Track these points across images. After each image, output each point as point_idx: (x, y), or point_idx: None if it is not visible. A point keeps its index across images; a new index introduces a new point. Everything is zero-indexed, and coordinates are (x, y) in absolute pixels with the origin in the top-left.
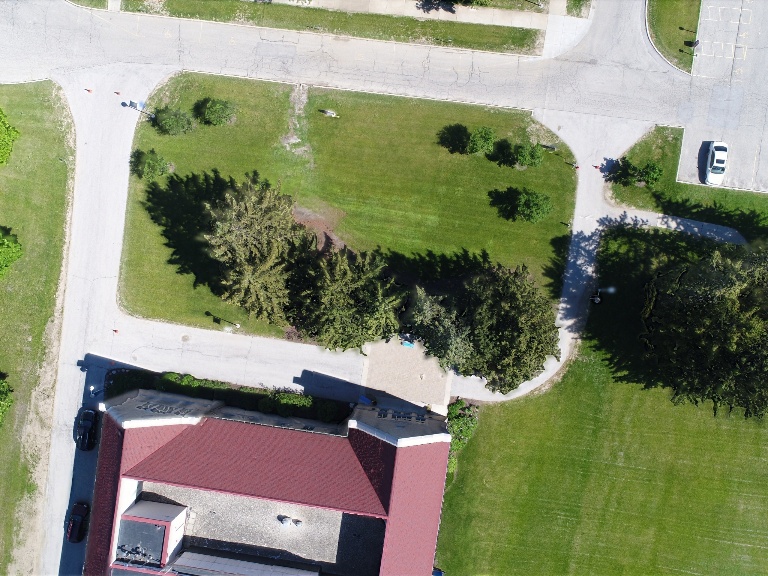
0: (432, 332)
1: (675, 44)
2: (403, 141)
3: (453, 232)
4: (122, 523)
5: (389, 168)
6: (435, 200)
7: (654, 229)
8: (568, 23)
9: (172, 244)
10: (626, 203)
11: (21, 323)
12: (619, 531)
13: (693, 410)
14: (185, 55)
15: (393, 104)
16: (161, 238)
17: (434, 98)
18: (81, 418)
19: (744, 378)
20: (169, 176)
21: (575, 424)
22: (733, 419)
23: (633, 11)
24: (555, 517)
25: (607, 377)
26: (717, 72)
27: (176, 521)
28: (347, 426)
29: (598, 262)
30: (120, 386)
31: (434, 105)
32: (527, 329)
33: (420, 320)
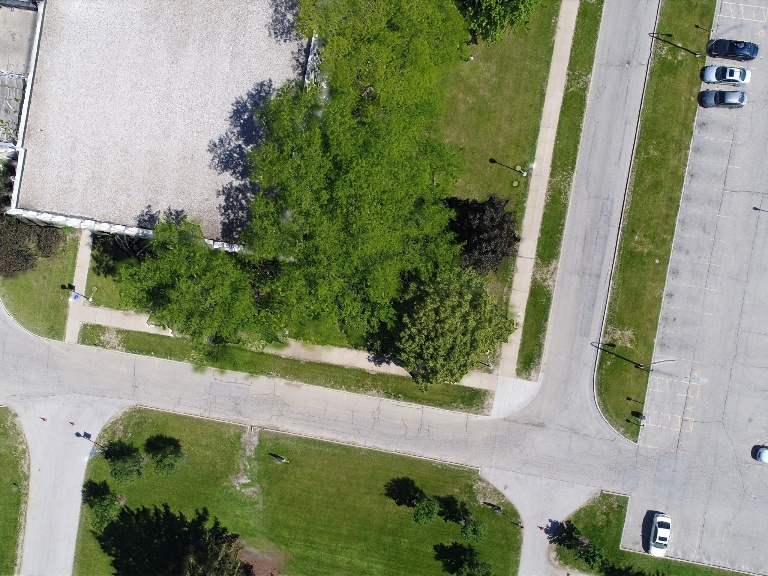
0: None
1: (622, 414)
2: (351, 490)
3: None
4: None
5: (337, 515)
6: (381, 549)
7: None
8: (517, 385)
9: (121, 575)
10: (570, 565)
11: None
12: None
13: None
14: (139, 390)
15: (342, 453)
16: (110, 568)
17: (383, 449)
18: None
19: None
20: (120, 508)
21: None
22: None
23: (582, 377)
24: None
25: None
26: (663, 443)
27: None
28: None
29: None
30: None
31: (383, 457)
32: None
33: None
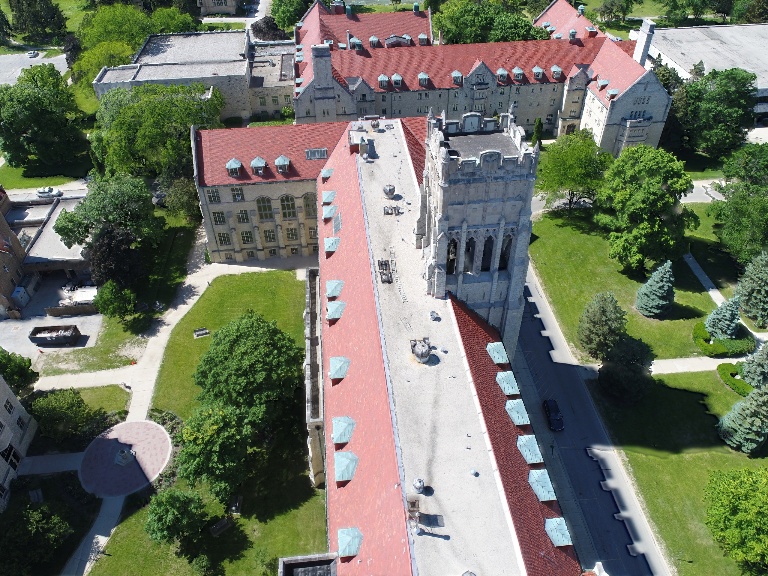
0: None
1: None
2: None
3: None
4: None
5: None
6: None
7: None
8: None
9: None
10: None
11: None
12: None
13: None
14: None
15: None
16: None
17: None
18: None
19: None
20: None
21: None
22: None
23: None
24: None
25: None
26: (25, 66)
27: None
28: None
29: None
30: None
31: None
32: None
33: None
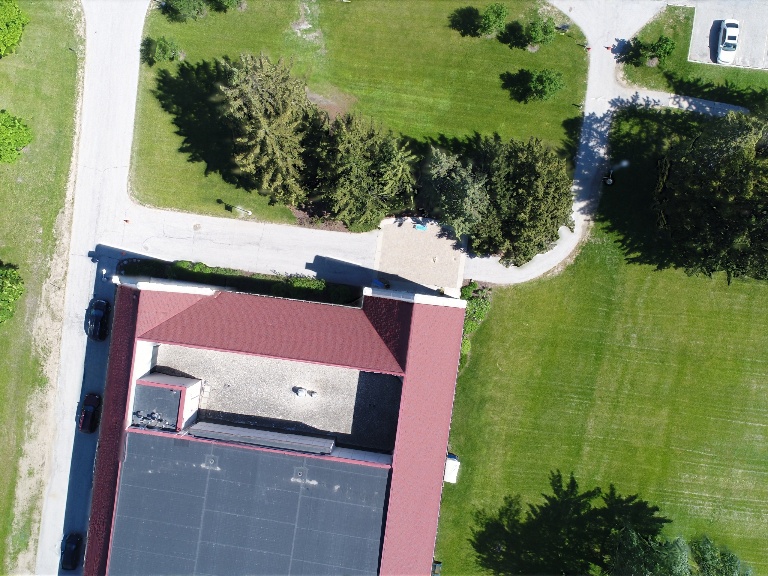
0: (448, 184)
1: None
2: (414, 25)
3: (465, 115)
4: (137, 389)
5: (400, 52)
6: (447, 84)
7: (666, 109)
8: None
9: (183, 132)
10: (638, 84)
11: (31, 215)
12: (632, 413)
13: (706, 290)
14: None
15: None
16: (172, 126)
17: None
18: (93, 307)
19: (759, 233)
20: (180, 64)
21: (588, 307)
22: (746, 299)
23: None
24: (568, 400)
25: (620, 259)
26: None
27: (191, 390)
28: (361, 298)
29: (610, 143)
30: (131, 276)
31: None
32: (544, 174)
33: (436, 173)
